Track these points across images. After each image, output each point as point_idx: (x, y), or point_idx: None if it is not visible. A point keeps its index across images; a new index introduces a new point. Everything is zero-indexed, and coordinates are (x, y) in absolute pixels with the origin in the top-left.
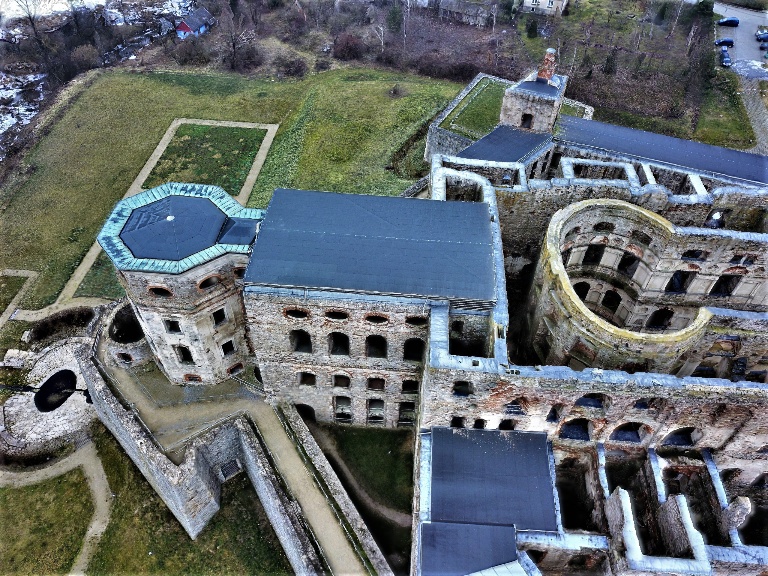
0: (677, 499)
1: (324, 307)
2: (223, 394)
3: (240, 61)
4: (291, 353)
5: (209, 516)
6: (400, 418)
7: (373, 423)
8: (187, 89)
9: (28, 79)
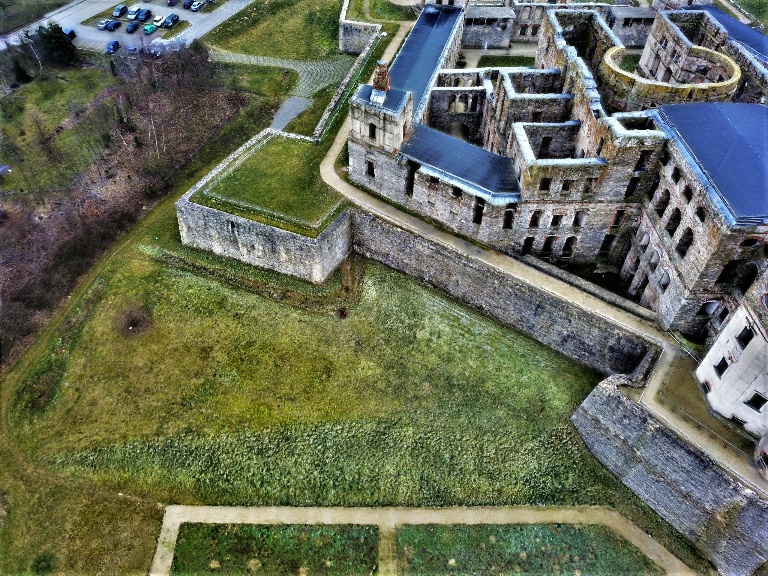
0: None
1: None
2: None
3: None
4: None
5: None
6: None
7: None
8: None
9: None
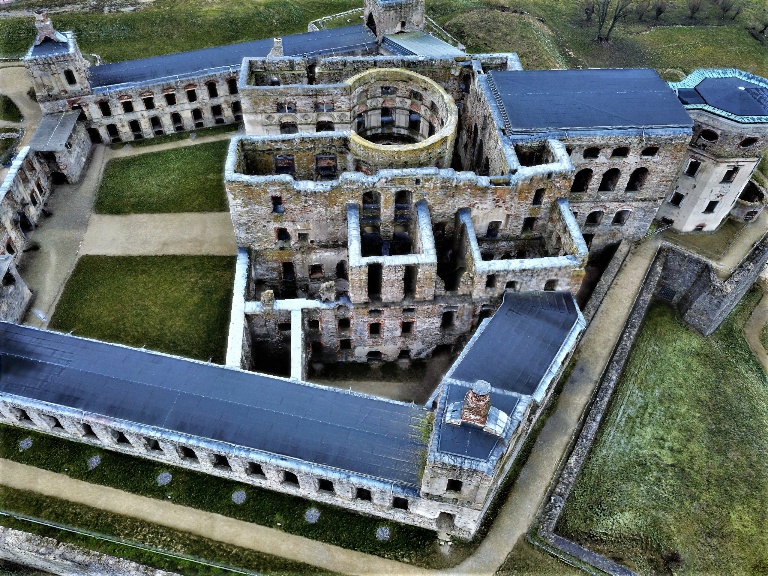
0: None
1: None
2: None
3: None
4: None
5: None
6: None
7: None
8: None
9: None
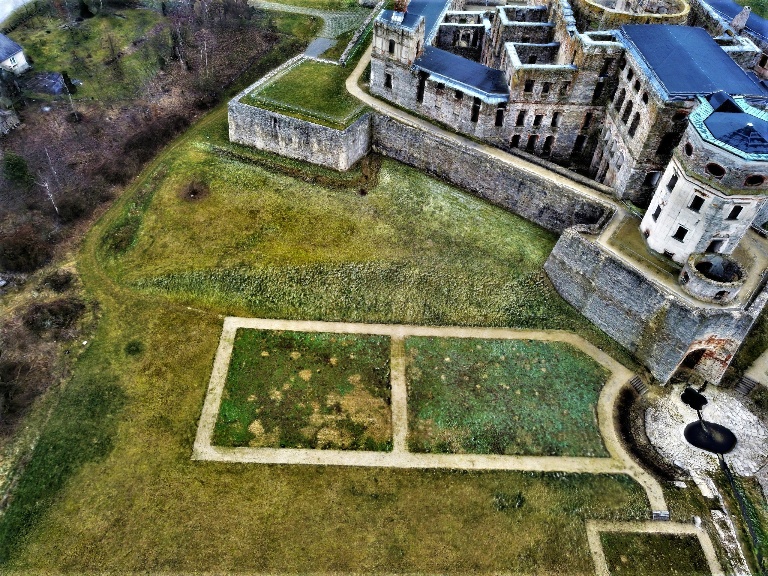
0: None
1: None
2: None
3: (16, 387)
4: None
5: None
6: None
7: None
8: (86, 467)
9: None
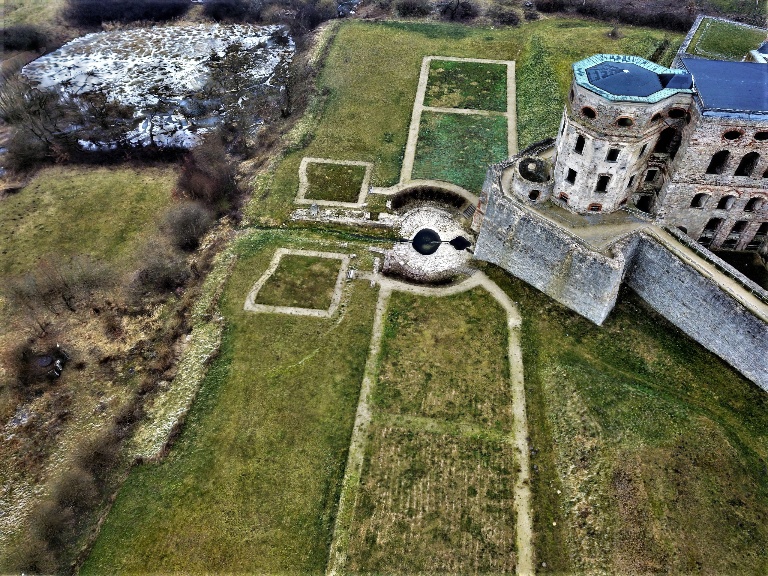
0: None
1: (759, 128)
2: (618, 219)
3: (461, 12)
4: (704, 174)
5: (610, 309)
6: (751, 241)
7: (724, 247)
8: (423, 34)
9: (272, 29)
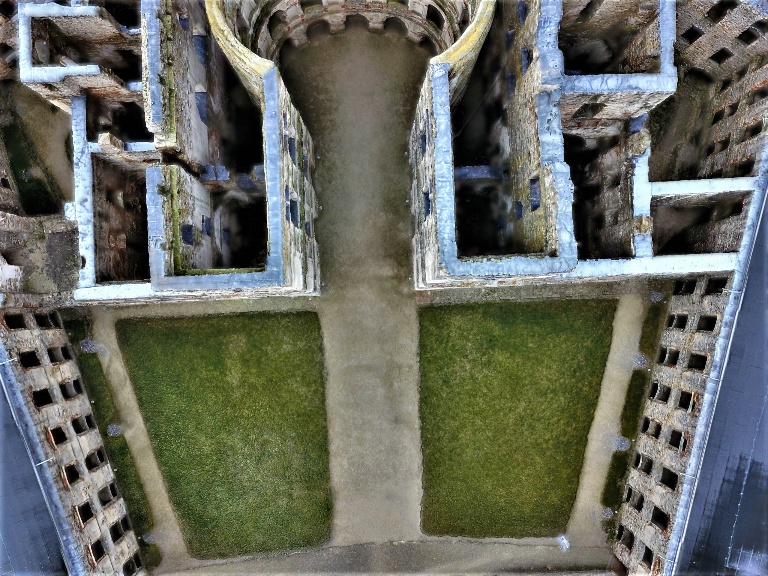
0: (94, 65)
1: None
2: None
3: None
4: None
5: None
6: None
7: None
8: None
9: None
